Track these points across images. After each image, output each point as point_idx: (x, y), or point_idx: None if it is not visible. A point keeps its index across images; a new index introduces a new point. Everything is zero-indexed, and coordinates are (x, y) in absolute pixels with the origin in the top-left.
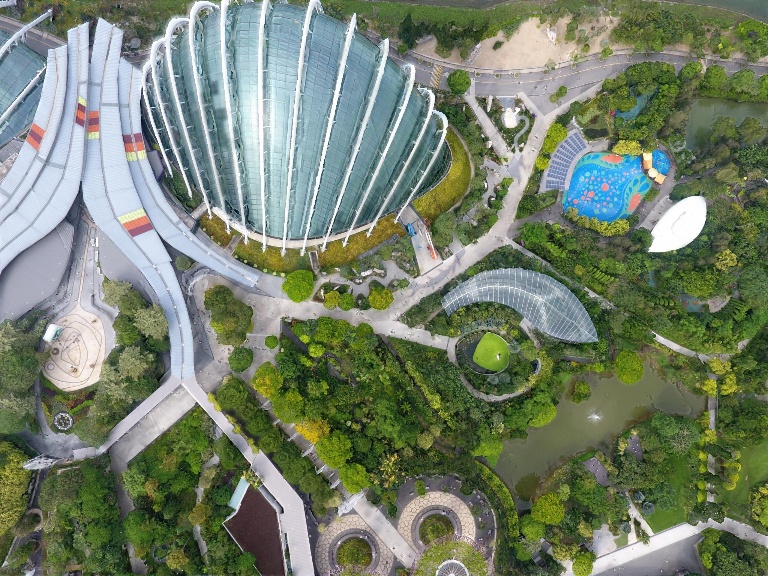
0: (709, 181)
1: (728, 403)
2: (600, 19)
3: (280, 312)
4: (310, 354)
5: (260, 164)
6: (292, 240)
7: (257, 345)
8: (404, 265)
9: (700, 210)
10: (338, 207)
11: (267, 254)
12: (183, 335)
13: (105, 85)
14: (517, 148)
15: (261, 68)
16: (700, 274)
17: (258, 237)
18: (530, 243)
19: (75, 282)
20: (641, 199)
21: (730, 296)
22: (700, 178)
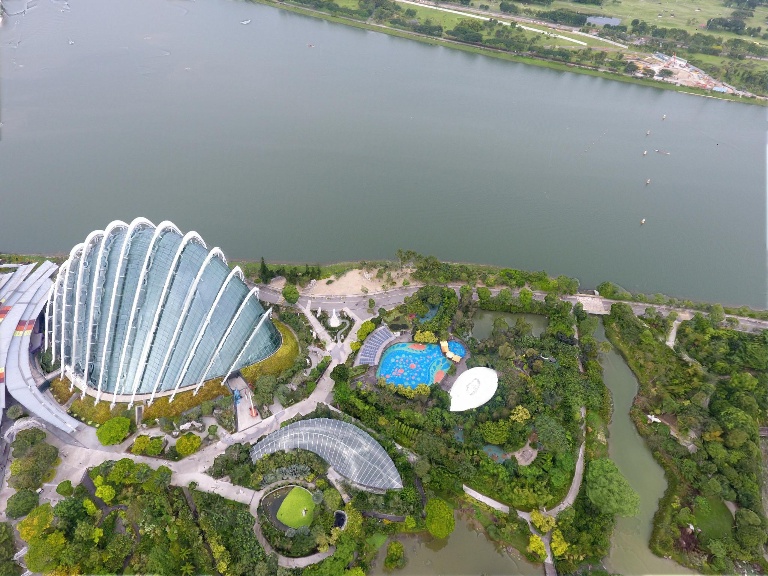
0: (493, 357)
1: (566, 569)
2: (403, 270)
3: (88, 462)
4: (95, 494)
5: None
6: (124, 395)
7: (50, 496)
8: (223, 421)
9: (491, 378)
10: (167, 361)
11: (97, 408)
12: None
13: (27, 293)
14: (339, 340)
15: (122, 255)
16: (495, 424)
17: (95, 393)
18: (342, 403)
19: None
20: (444, 374)
21: (537, 450)
22: (485, 354)
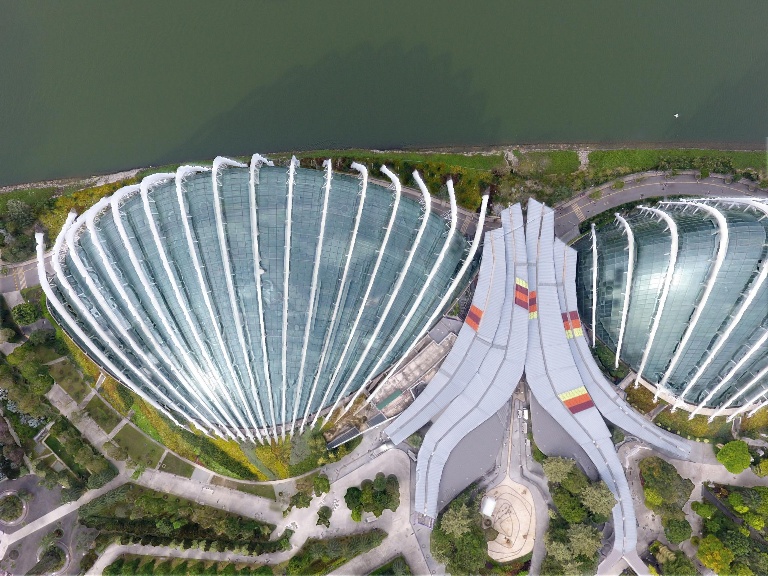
0: None
1: None
2: None
3: (701, 477)
4: (754, 527)
5: (746, 358)
6: None
7: None
8: None
9: None
10: None
11: (693, 422)
12: (624, 509)
13: (540, 265)
14: None
15: None
16: None
17: None
18: None
19: (503, 453)
20: None
21: None
22: None
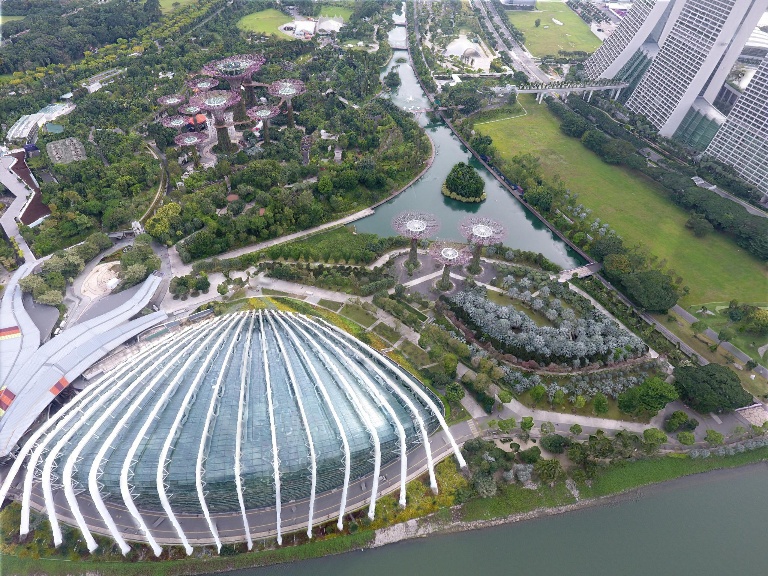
0: None
1: None
2: None
3: None
4: None
5: None
6: None
7: None
8: None
9: None
10: None
11: None
12: None
13: None
14: None
15: None
16: None
17: None
18: None
19: None
20: None
21: None
22: None
